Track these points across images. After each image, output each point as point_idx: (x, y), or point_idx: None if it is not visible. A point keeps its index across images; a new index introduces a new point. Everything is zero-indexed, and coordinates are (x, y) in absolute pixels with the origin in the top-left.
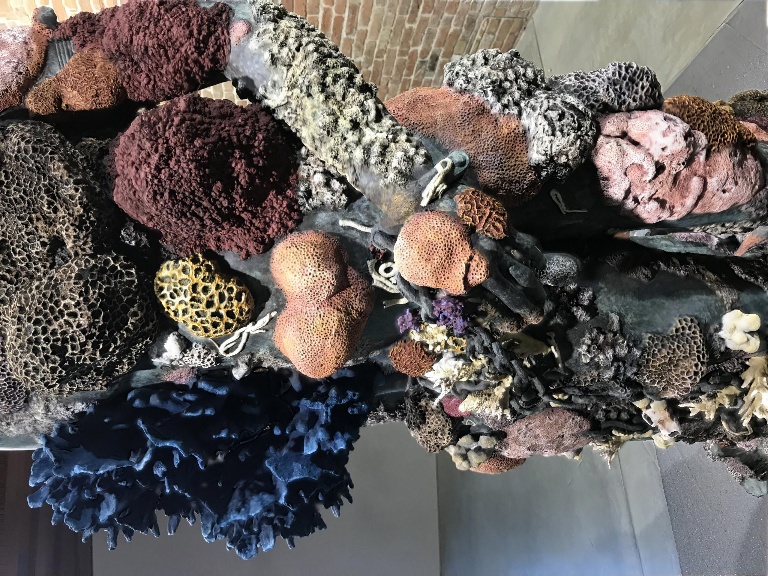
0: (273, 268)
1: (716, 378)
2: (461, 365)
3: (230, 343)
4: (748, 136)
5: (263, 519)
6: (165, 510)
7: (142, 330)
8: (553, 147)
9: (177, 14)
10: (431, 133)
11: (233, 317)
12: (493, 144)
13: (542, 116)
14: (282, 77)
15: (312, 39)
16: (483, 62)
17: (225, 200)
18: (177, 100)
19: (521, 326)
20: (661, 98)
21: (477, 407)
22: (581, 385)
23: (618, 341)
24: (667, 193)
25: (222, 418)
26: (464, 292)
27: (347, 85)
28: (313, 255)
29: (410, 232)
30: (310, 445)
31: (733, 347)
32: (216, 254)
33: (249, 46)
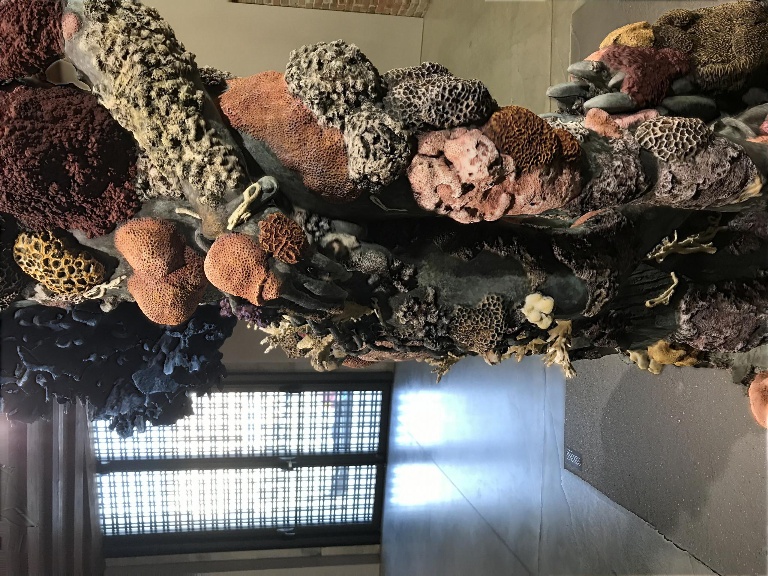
0: (117, 246)
1: (527, 332)
2: (287, 326)
3: (91, 292)
4: (569, 152)
5: (135, 412)
6: (56, 399)
7: (6, 289)
8: (366, 168)
9: (6, 7)
10: (261, 136)
11: (84, 283)
12: (316, 155)
13: (359, 138)
14: (111, 84)
15: (139, 47)
16: (317, 68)
17: (63, 197)
18: (11, 101)
19: (324, 316)
20: (491, 111)
21: (311, 347)
22: (401, 337)
23: (431, 310)
24: (477, 205)
25: (92, 344)
26: (259, 305)
27: (170, 101)
28: (148, 243)
29: (216, 252)
30: (168, 367)
31: (531, 321)
32: (65, 231)
33: (79, 46)
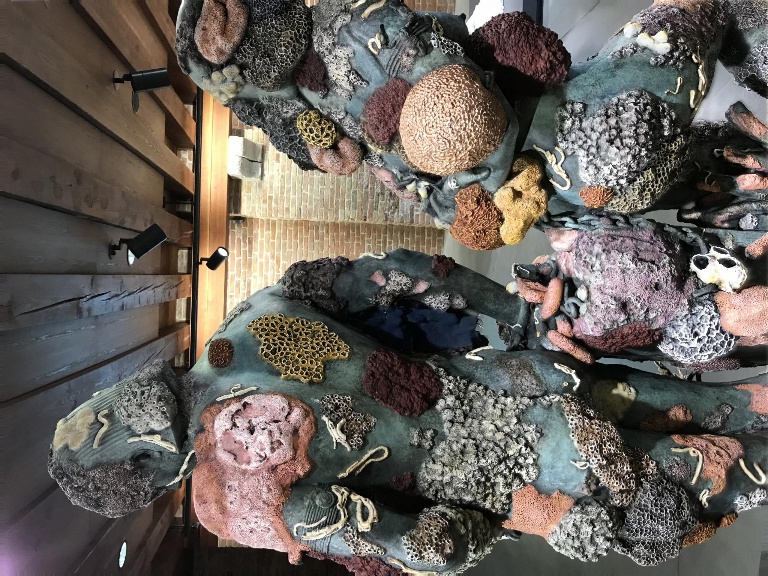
0: None
1: None
2: None
3: None
4: None
5: None
6: None
7: None
8: None
9: None
10: None
11: None
12: None
13: None
14: None
15: None
16: None
17: None
18: None
19: None
20: None
21: None
22: None
23: None
24: None
25: None
26: None
27: None
28: None
29: None
30: None
31: None
32: None
33: None
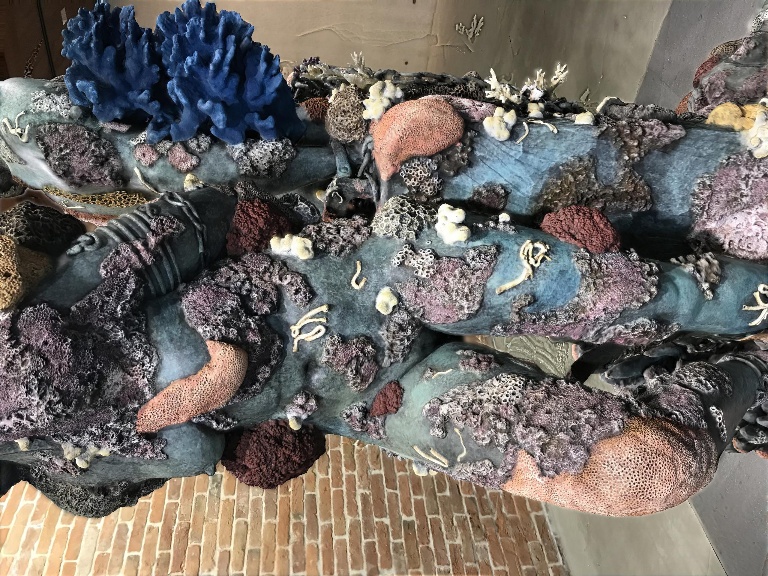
0: None
1: None
2: None
3: None
4: None
5: None
6: None
7: None
8: None
9: None
10: None
11: None
12: None
13: None
14: None
15: None
16: None
17: None
18: None
19: None
20: None
21: None
22: None
23: None
24: None
25: None
26: None
27: None
28: None
29: None
30: None
31: None
32: None
33: None
